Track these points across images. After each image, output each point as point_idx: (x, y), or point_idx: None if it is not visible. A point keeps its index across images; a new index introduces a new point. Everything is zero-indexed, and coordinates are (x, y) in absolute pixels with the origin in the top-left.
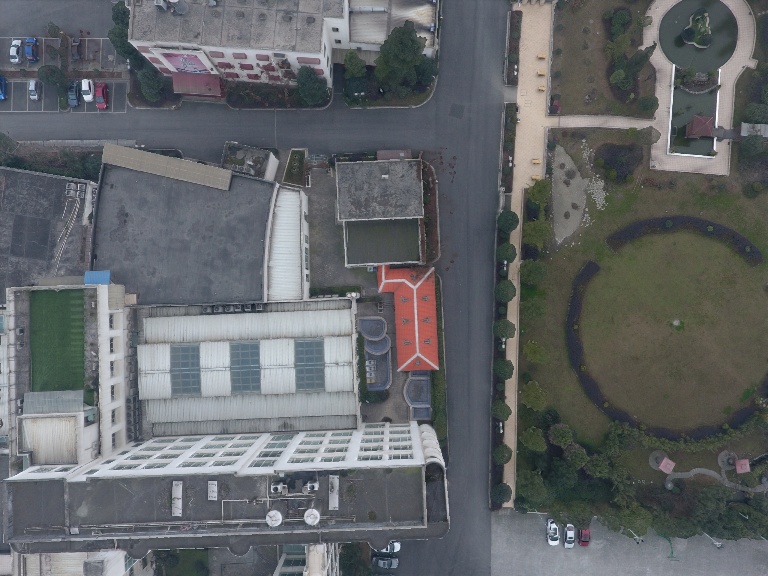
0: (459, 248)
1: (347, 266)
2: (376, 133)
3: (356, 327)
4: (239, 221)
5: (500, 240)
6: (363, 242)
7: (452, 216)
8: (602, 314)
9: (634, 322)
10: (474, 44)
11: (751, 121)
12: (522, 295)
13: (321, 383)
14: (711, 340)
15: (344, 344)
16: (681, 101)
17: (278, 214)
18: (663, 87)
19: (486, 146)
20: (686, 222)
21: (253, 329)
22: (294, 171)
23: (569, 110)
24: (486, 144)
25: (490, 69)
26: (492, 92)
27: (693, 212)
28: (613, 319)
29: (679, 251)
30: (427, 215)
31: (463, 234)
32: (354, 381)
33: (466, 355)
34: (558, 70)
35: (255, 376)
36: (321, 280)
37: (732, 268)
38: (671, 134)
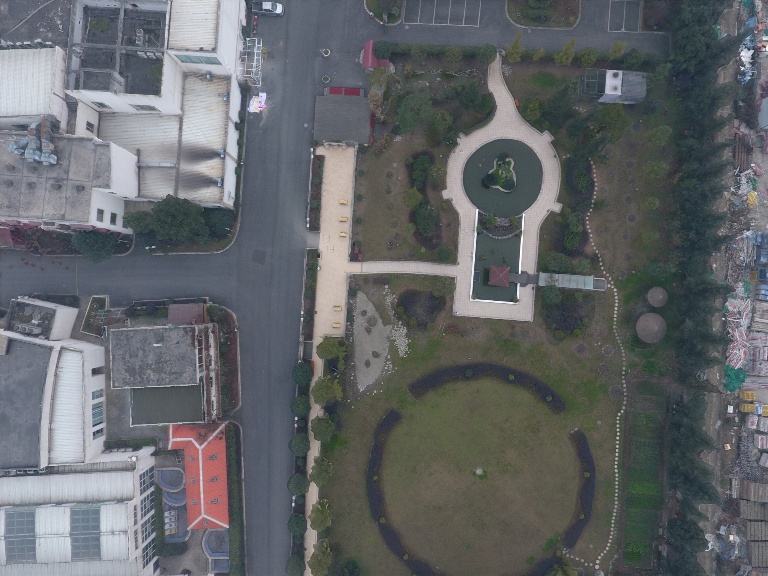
0: (260, 396)
1: (132, 426)
2: (178, 279)
3: (152, 480)
4: (18, 385)
5: (300, 389)
6: (148, 402)
7: (253, 364)
8: (404, 463)
9: (436, 471)
10: (277, 188)
11: (549, 270)
12: (322, 445)
13: (97, 552)
14: (514, 489)
15: (120, 512)
16: (485, 245)
17: (60, 375)
18: (467, 232)
19: (288, 292)
20: (488, 370)
21: (35, 492)
22: (91, 321)
23: (372, 255)
24: (288, 290)
25: (293, 214)
26: (295, 237)
27: (497, 359)
28: (415, 468)
29: (482, 398)
30: (226, 364)
31: (264, 382)
32: (129, 551)
33: (266, 506)
34: (361, 215)
35: (30, 545)
36: (118, 432)
37: (536, 415)
38: (474, 279)
